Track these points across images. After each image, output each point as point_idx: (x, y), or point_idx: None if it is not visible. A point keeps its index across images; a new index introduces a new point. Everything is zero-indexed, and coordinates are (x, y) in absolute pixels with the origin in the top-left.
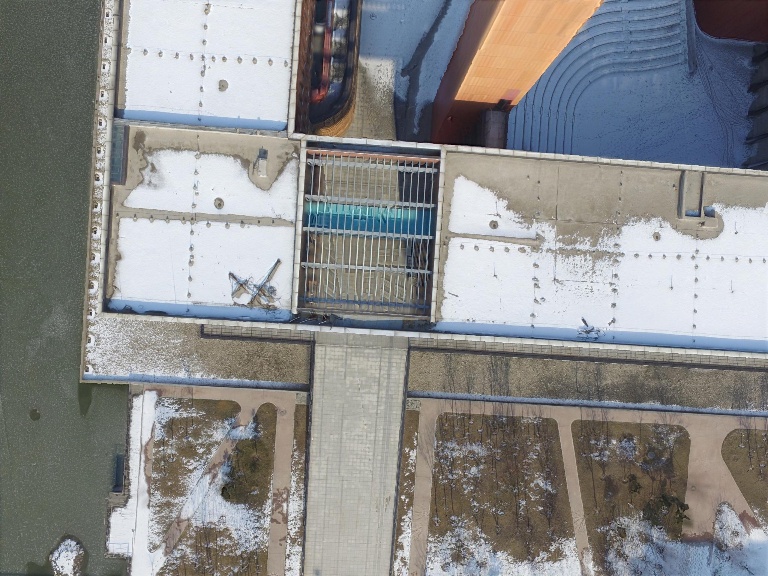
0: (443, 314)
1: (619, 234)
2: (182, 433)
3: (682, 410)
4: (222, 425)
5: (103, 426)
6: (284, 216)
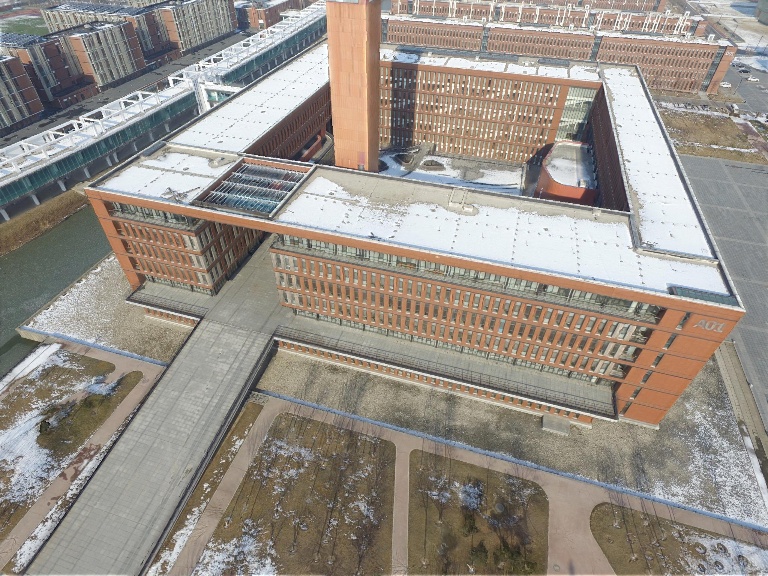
0: (280, 217)
1: (408, 206)
2: (53, 379)
3: (538, 468)
4: (89, 379)
5: None
6: (215, 176)
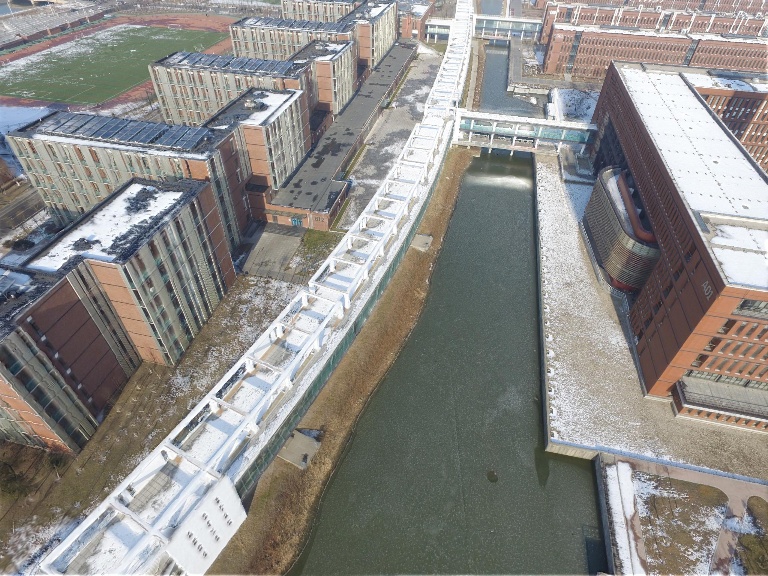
0: None
1: None
2: (667, 515)
3: None
4: (712, 512)
5: (565, 501)
6: None
